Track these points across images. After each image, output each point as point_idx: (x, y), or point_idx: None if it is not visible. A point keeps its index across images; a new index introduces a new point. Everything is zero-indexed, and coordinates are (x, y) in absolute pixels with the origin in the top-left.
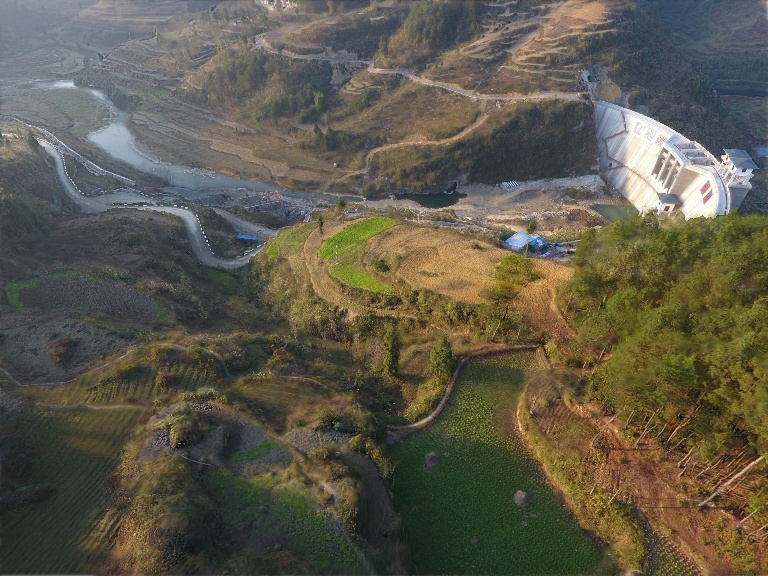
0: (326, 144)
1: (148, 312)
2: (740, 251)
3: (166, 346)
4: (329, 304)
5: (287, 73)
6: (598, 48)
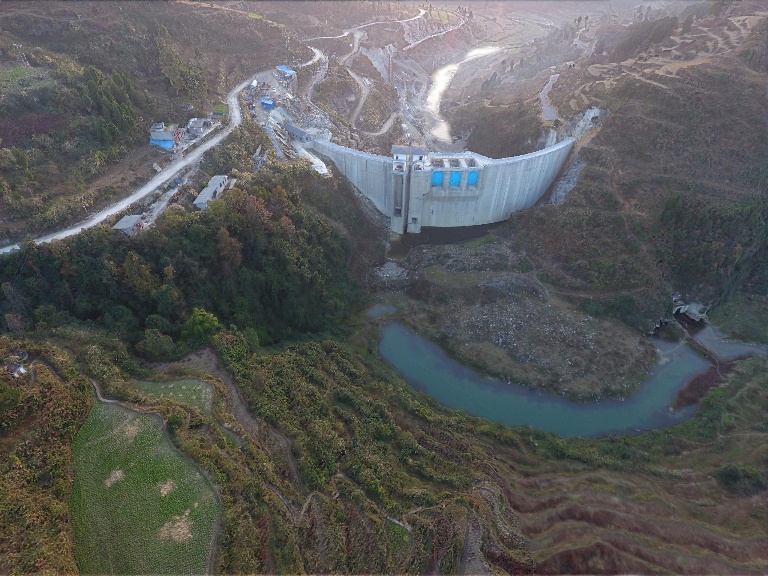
0: (482, 85)
1: (225, 5)
2: None
3: None
4: None
5: None
6: (628, 95)
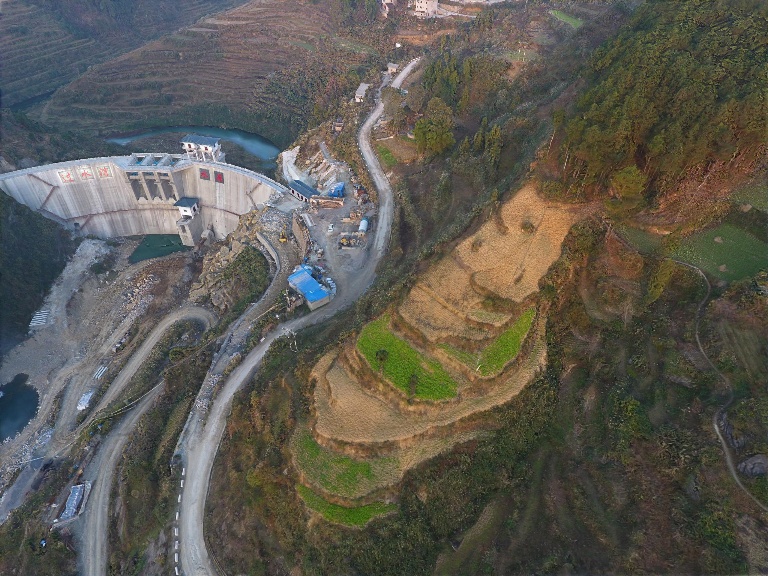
0: None
1: None
2: (637, 97)
3: (763, 446)
4: (536, 378)
5: None
6: None
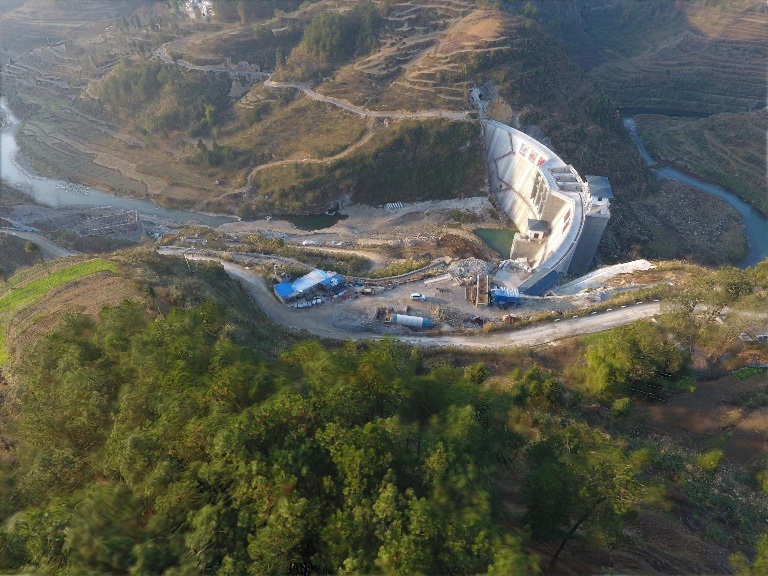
0: (209, 160)
1: None
2: None
3: None
4: None
5: (180, 84)
6: (489, 66)
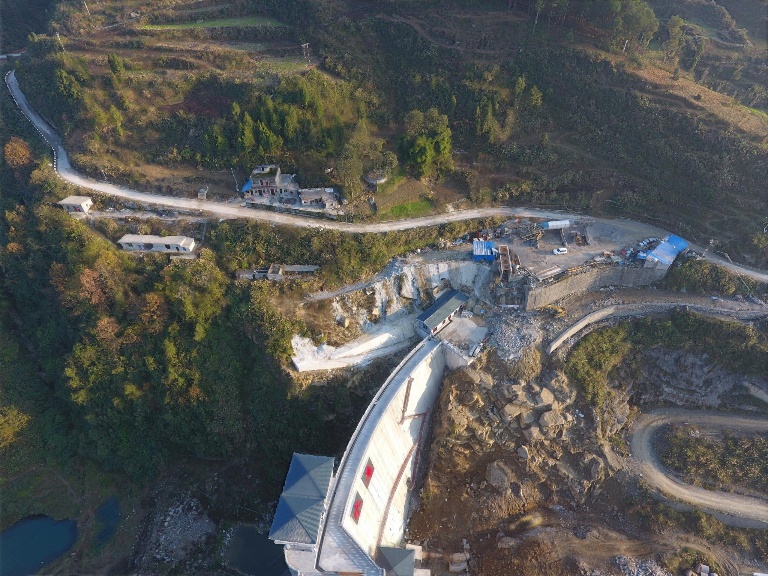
0: None
1: None
2: None
3: None
4: None
5: None
6: None
